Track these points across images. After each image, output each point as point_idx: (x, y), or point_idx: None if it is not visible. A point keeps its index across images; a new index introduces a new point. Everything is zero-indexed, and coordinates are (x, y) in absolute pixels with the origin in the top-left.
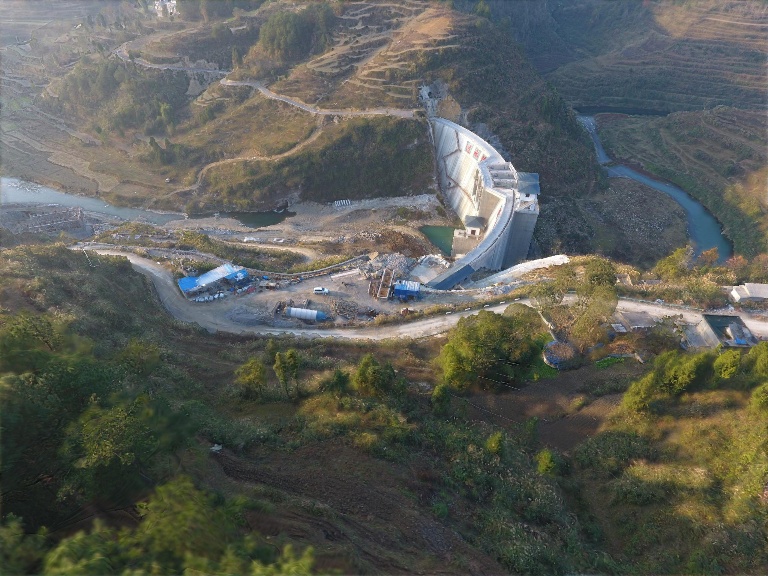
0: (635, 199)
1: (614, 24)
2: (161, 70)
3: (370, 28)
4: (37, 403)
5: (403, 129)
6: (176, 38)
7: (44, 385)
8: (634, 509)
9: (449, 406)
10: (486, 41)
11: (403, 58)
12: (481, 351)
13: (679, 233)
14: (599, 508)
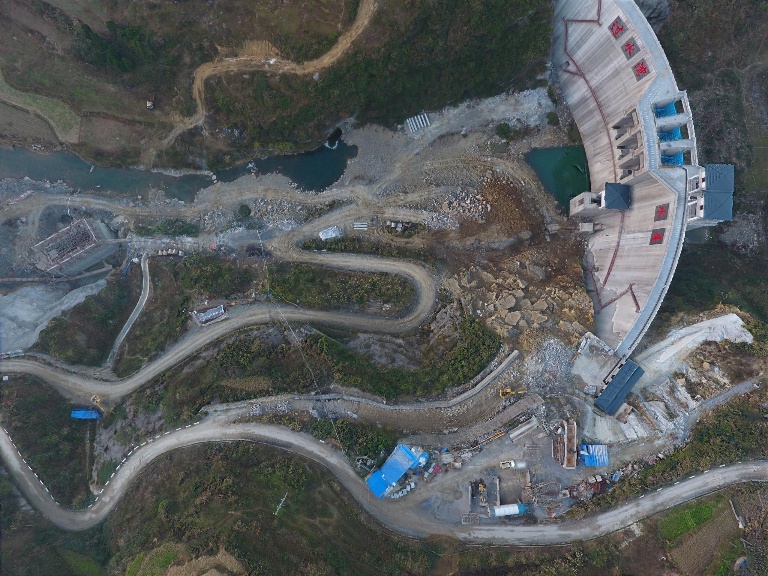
0: None
1: None
2: None
3: None
4: None
5: None
6: None
7: None
8: None
9: None
10: None
11: None
12: None
13: None
14: None
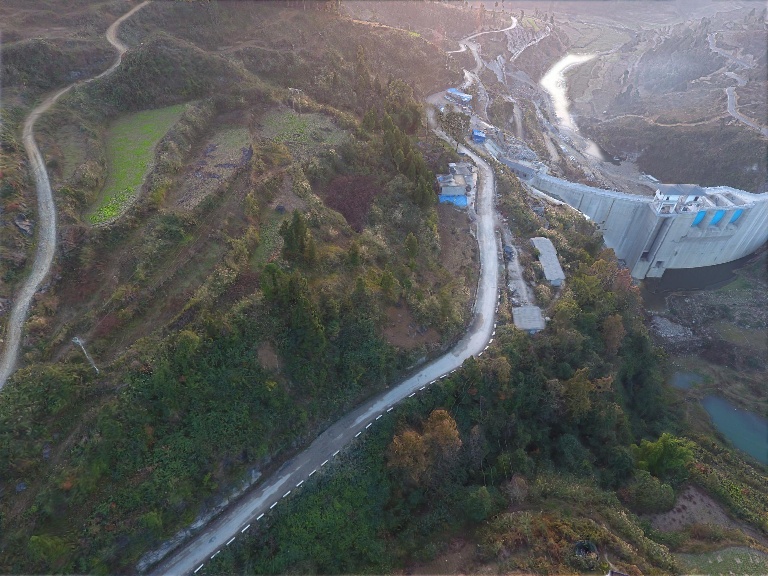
0: None
1: None
2: (711, 51)
3: None
4: None
5: (754, 149)
6: (755, 32)
7: None
8: None
9: None
10: None
11: None
12: None
13: None
14: None
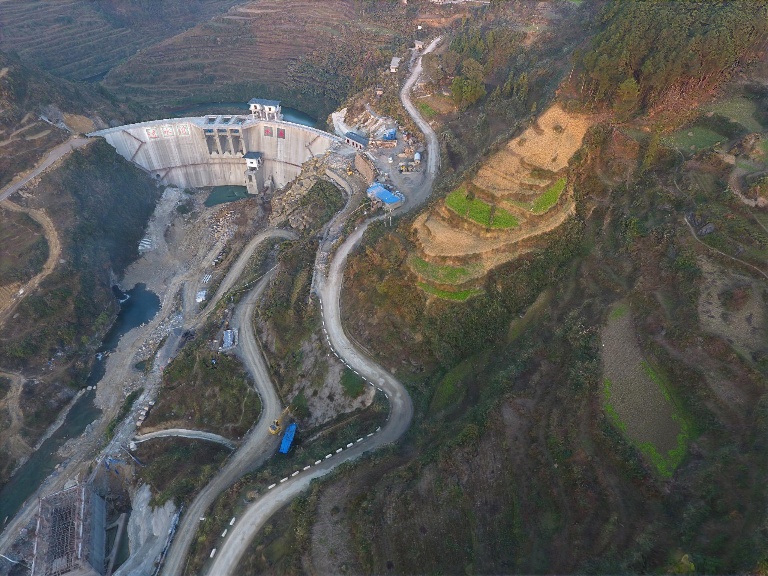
0: None
1: None
2: None
3: None
4: None
5: (100, 153)
6: None
7: None
8: None
9: None
10: None
11: None
12: None
13: None
14: None
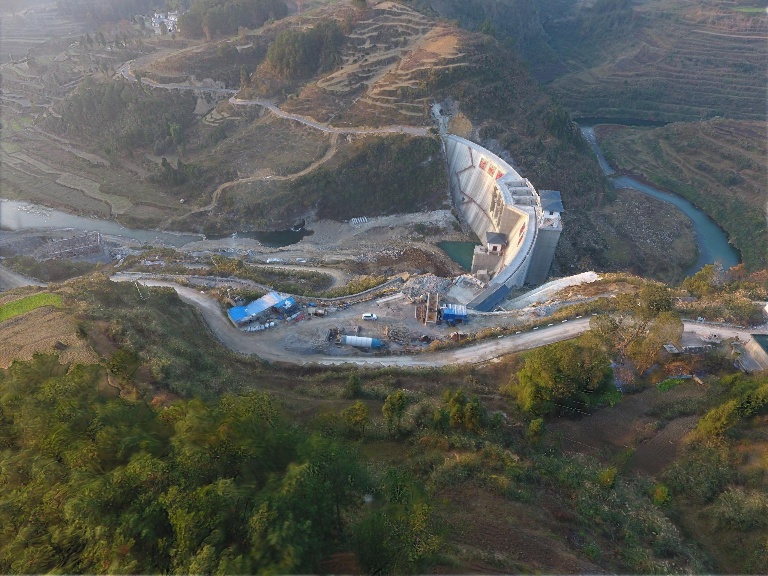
0: (643, 210)
1: (605, 36)
2: (168, 90)
3: (378, 47)
4: (321, 492)
5: (418, 147)
6: (182, 57)
7: (318, 473)
8: (739, 535)
9: (544, 439)
10: (493, 59)
11: (414, 76)
12: (560, 381)
13: (689, 243)
14: (703, 535)
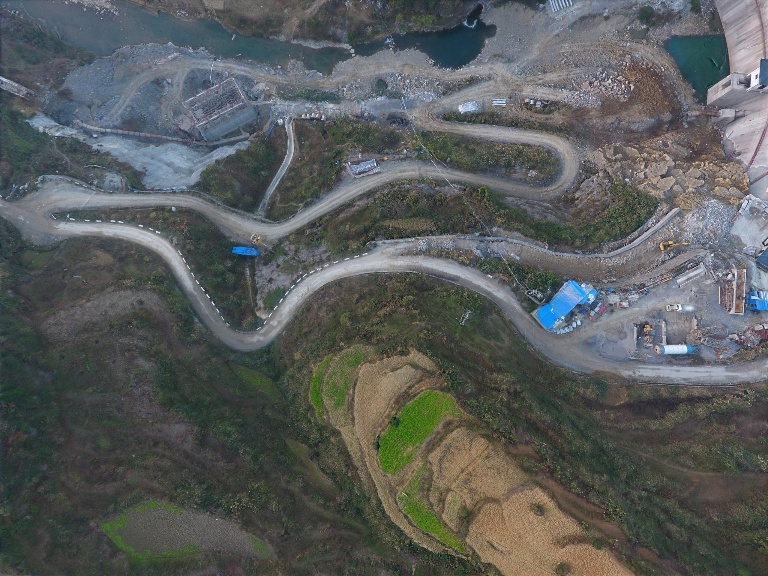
0: None
1: None
2: None
3: None
4: None
5: None
6: None
7: None
8: None
9: None
10: None
11: None
12: None
13: None
14: None
